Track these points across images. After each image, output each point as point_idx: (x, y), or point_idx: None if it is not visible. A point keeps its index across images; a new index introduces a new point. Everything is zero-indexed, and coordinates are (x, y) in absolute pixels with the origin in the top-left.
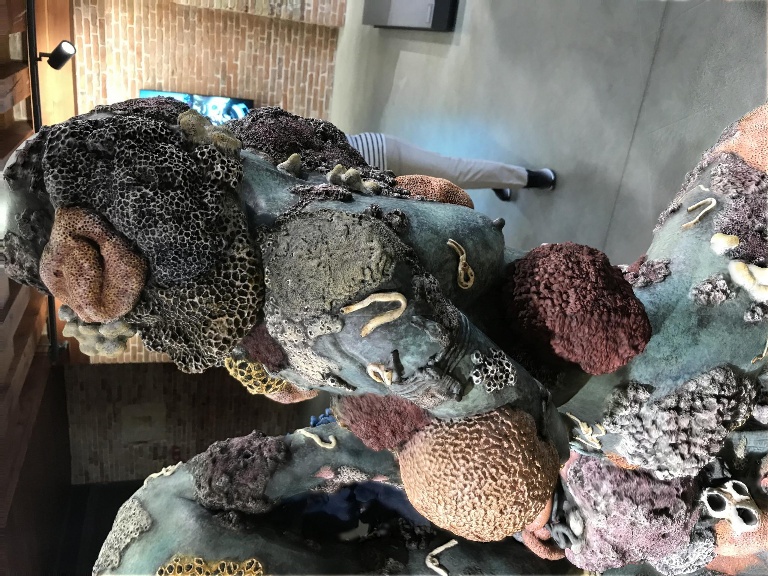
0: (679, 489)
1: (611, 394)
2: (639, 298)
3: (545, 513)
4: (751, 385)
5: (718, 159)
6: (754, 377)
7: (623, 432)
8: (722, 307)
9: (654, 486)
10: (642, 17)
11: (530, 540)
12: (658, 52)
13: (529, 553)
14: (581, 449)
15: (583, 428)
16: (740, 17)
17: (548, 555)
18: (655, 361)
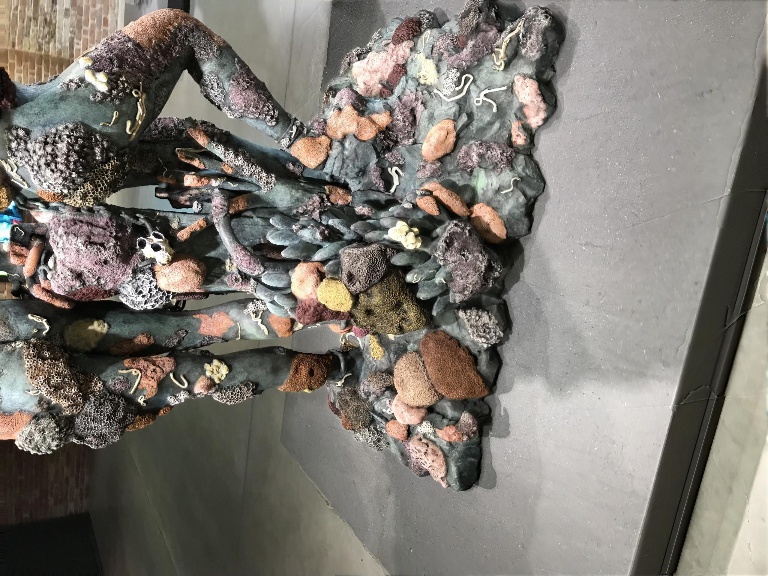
0: (113, 233)
1: (4, 134)
2: (29, 87)
3: (33, 259)
4: (102, 138)
5: None
6: (108, 136)
7: (22, 162)
8: (76, 92)
9: (92, 228)
10: (283, 33)
11: (36, 288)
12: (291, 57)
13: (40, 301)
14: (43, 207)
15: (5, 165)
16: (326, 26)
17: (49, 297)
18: (29, 115)
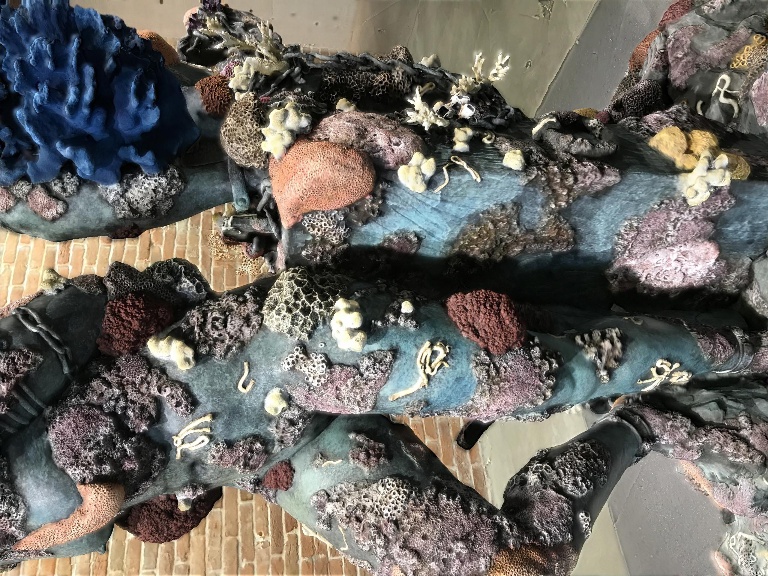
0: None
1: None
2: None
3: None
4: None
5: (378, 570)
6: None
7: None
8: None
9: None
10: None
11: None
12: None
13: None
14: None
15: None
16: None
17: None
18: None
